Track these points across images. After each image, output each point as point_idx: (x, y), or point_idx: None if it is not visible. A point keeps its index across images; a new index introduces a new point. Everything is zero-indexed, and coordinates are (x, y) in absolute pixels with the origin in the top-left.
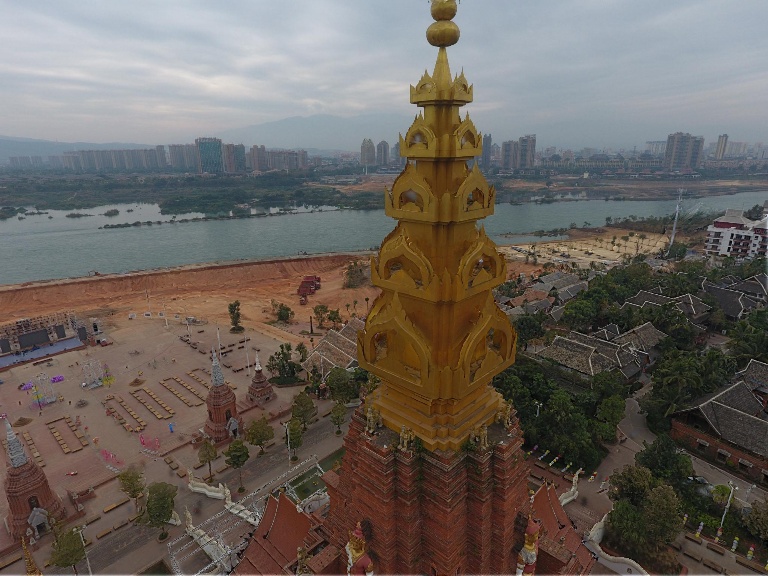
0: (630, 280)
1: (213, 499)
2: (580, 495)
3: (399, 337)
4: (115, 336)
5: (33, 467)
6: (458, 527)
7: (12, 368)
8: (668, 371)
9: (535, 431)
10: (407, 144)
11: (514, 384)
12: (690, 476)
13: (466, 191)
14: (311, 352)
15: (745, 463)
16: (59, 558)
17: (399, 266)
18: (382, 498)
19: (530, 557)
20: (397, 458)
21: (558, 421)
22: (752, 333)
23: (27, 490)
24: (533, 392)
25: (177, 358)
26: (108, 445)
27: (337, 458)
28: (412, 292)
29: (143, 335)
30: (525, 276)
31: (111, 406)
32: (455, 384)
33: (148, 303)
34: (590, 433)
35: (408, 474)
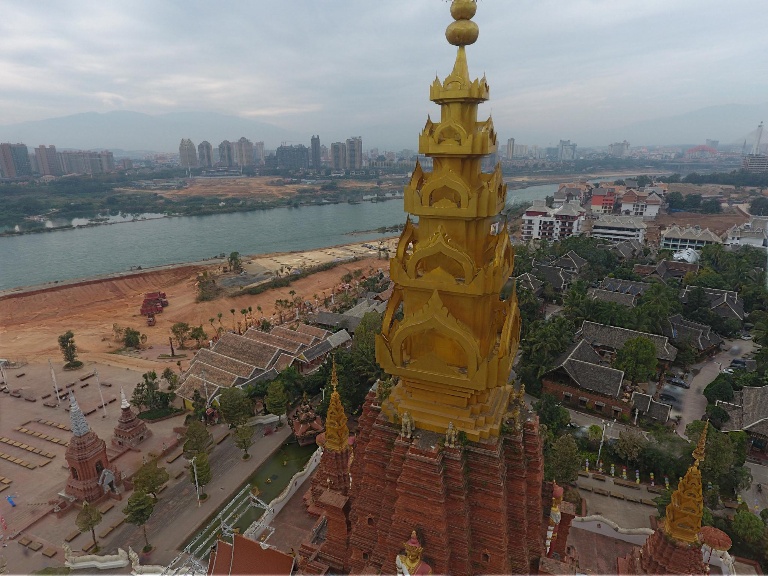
0: None
1: (111, 570)
2: None
3: (428, 336)
4: None
5: None
6: None
7: None
8: (535, 339)
9: None
10: (435, 141)
11: None
12: None
13: None
14: (183, 376)
15: (600, 404)
16: None
17: None
18: (437, 500)
19: (558, 518)
20: (446, 456)
21: None
22: (580, 299)
23: None
24: None
25: None
26: None
27: (252, 484)
28: (452, 288)
29: None
30: (383, 271)
31: None
32: (501, 372)
33: None
34: None
35: (460, 469)
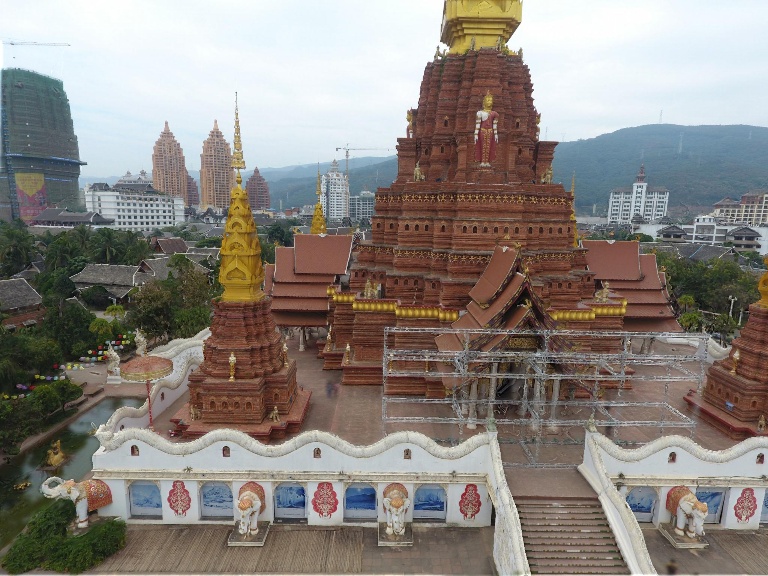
0: None
1: None
2: None
3: None
4: None
5: None
6: None
7: None
8: None
9: (9, 361)
10: None
11: None
12: None
13: None
14: None
15: (30, 323)
16: None
17: None
18: None
19: None
20: None
21: None
22: None
23: None
24: None
25: None
26: None
27: None
28: None
29: None
30: None
31: None
32: None
33: None
34: None
35: None
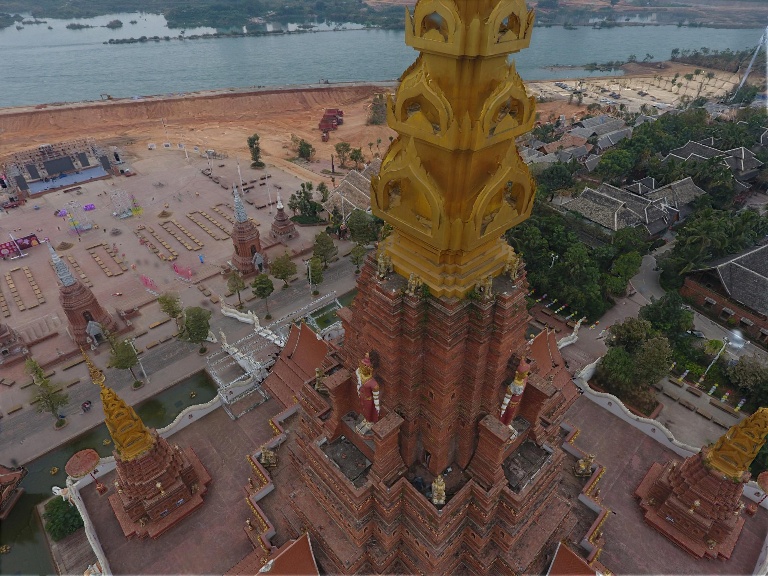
0: (681, 128)
1: (244, 323)
2: (579, 340)
3: (413, 185)
4: (137, 167)
5: (81, 287)
6: (456, 362)
7: (45, 194)
8: (695, 230)
9: (547, 281)
10: None
11: (533, 235)
12: (689, 330)
13: (499, 16)
14: (332, 192)
15: (746, 322)
16: (117, 362)
17: (418, 106)
18: (389, 335)
19: (518, 390)
20: (404, 301)
21: (571, 273)
22: None
23: (80, 306)
24: (551, 244)
25: (201, 192)
26: (146, 271)
27: None
28: (429, 138)
29: (165, 167)
30: (565, 118)
31: (143, 236)
32: (465, 236)
33: (166, 133)
34: (600, 286)
35: (414, 316)
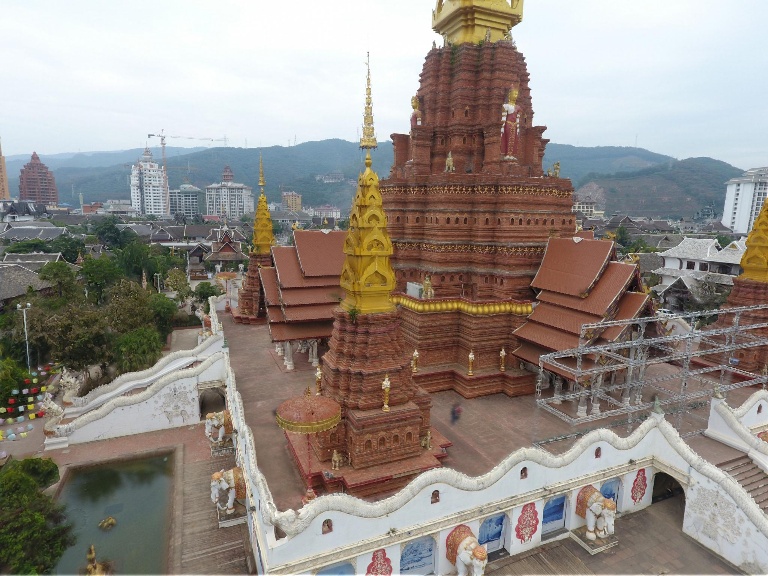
0: None
1: None
2: None
3: None
4: None
5: None
6: None
7: None
8: None
9: None
10: None
11: None
12: None
13: None
14: None
15: None
16: None
17: None
18: None
19: None
20: None
21: None
22: None
23: None
24: None
25: None
26: None
27: None
28: None
29: None
30: None
31: None
32: None
33: None
34: None
35: None
